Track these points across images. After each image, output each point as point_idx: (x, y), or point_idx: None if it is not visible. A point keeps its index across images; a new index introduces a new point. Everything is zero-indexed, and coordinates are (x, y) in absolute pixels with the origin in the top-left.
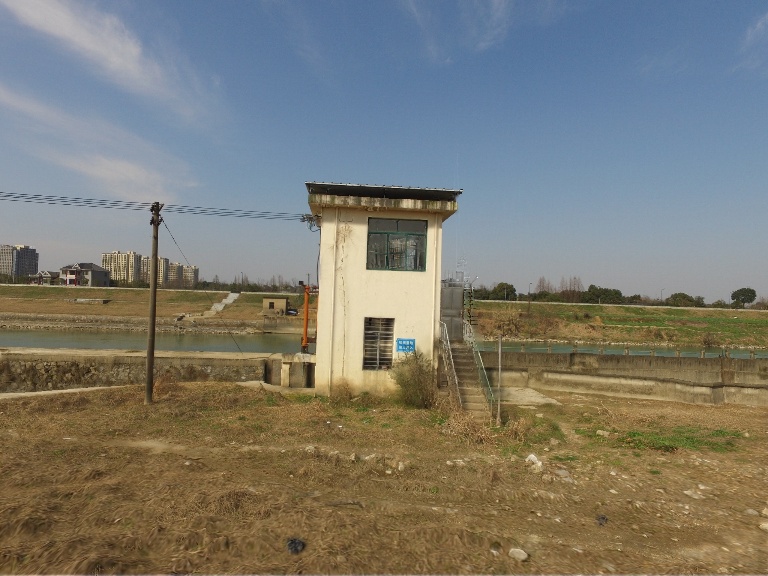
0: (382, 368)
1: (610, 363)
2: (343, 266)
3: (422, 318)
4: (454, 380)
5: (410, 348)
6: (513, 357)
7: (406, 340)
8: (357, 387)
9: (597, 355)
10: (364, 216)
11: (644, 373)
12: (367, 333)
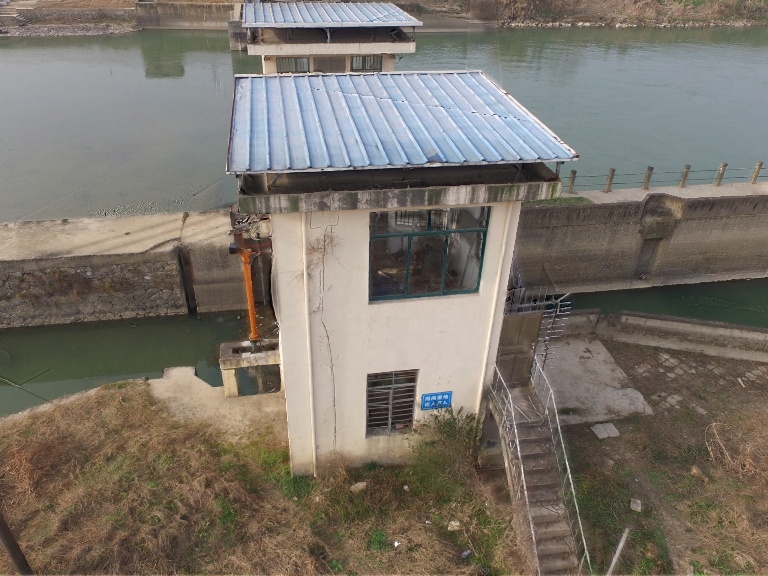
0: (396, 428)
1: (699, 211)
2: (324, 305)
3: (466, 363)
4: (529, 530)
5: (443, 403)
6: (561, 214)
7: (437, 394)
8: (358, 458)
9: (684, 201)
10: (362, 212)
11: (742, 220)
12: (372, 391)
